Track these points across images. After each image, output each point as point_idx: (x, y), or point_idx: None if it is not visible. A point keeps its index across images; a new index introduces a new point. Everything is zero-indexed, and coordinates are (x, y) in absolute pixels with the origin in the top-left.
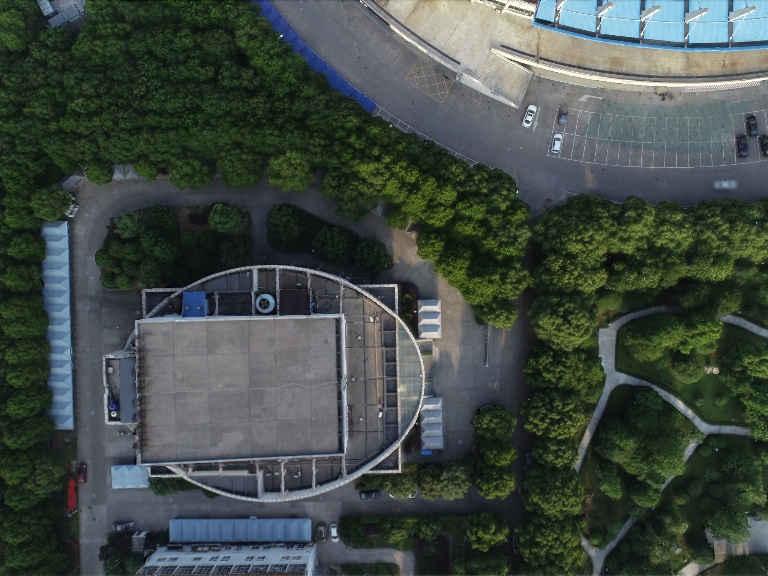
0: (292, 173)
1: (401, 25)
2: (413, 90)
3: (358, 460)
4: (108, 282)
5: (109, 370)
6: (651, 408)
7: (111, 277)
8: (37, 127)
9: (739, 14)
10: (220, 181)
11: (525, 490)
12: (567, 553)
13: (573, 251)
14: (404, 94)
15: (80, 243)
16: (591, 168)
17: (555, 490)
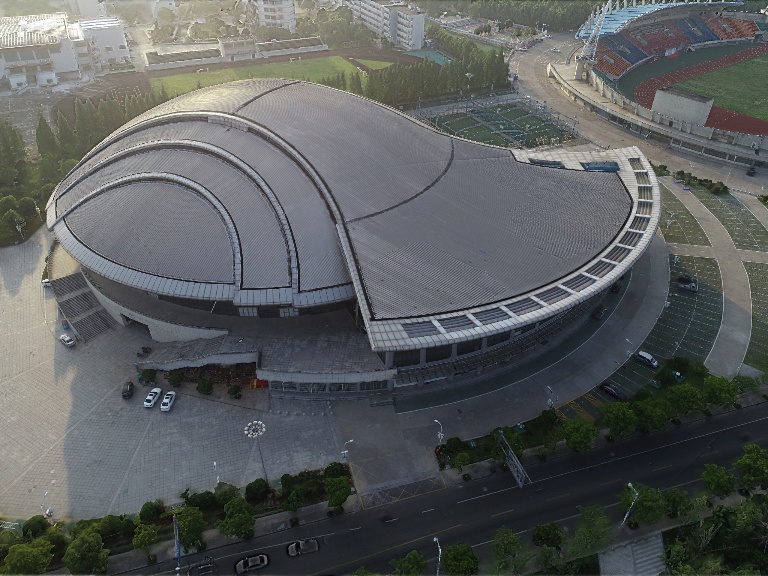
0: None
1: None
2: None
3: None
4: None
5: None
6: (599, 0)
7: None
8: None
9: None
10: None
11: None
12: None
13: None
14: None
15: None
16: None
17: None
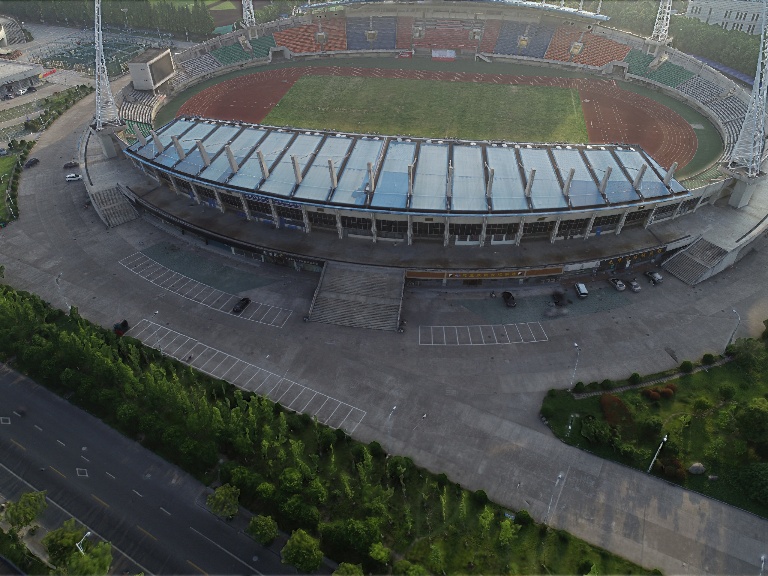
0: None
1: None
2: None
3: None
4: None
5: None
6: None
7: None
8: None
9: None
10: None
11: None
12: None
13: None
14: None
15: None
16: None
17: None
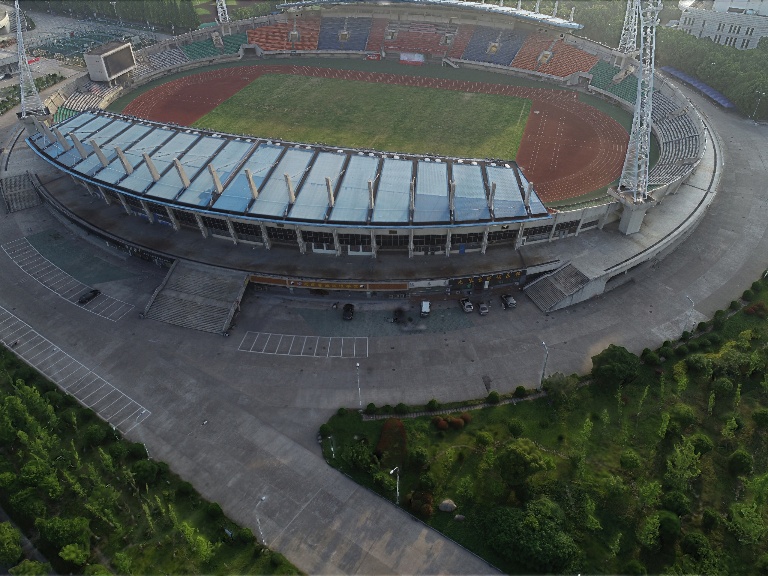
0: None
1: None
2: None
3: None
4: None
5: None
6: None
7: None
8: None
9: None
10: None
11: None
12: None
13: None
14: None
15: None
16: None
17: None
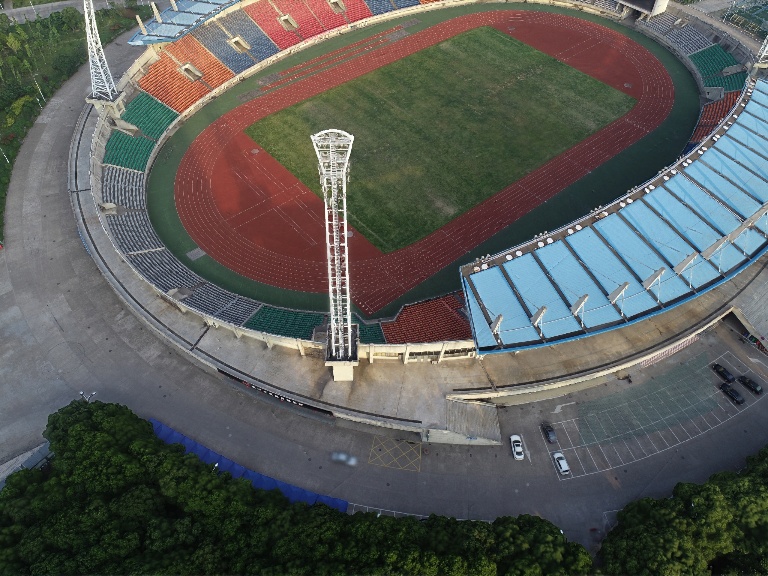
0: None
1: (344, 409)
2: (382, 470)
3: None
4: None
5: None
6: None
7: None
8: None
9: (652, 280)
10: None
11: None
12: None
13: None
14: (374, 478)
15: None
16: (612, 475)
17: None
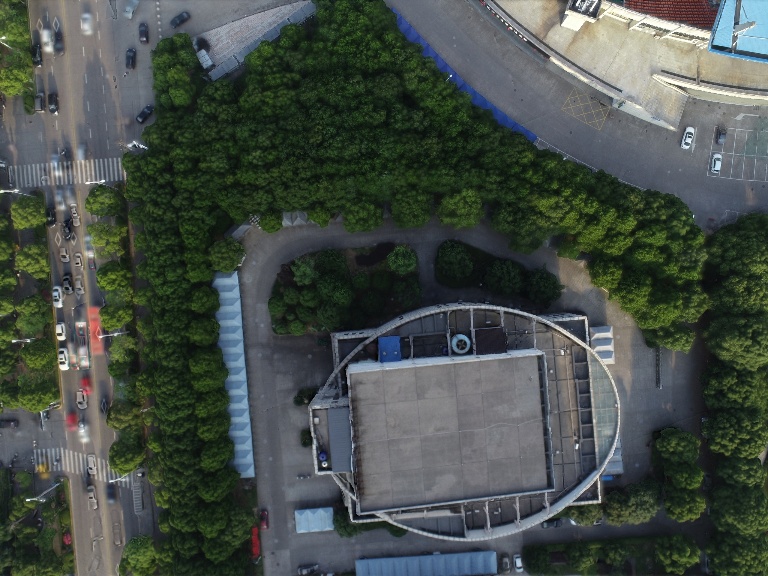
0: (467, 211)
1: (561, 57)
2: (570, 119)
3: (556, 493)
4: (283, 329)
5: (315, 420)
6: None
7: (284, 324)
8: (215, 181)
9: None
10: (385, 221)
11: (715, 511)
12: (766, 572)
13: (757, 272)
14: (561, 124)
15: (249, 291)
16: (751, 186)
17: (751, 510)
